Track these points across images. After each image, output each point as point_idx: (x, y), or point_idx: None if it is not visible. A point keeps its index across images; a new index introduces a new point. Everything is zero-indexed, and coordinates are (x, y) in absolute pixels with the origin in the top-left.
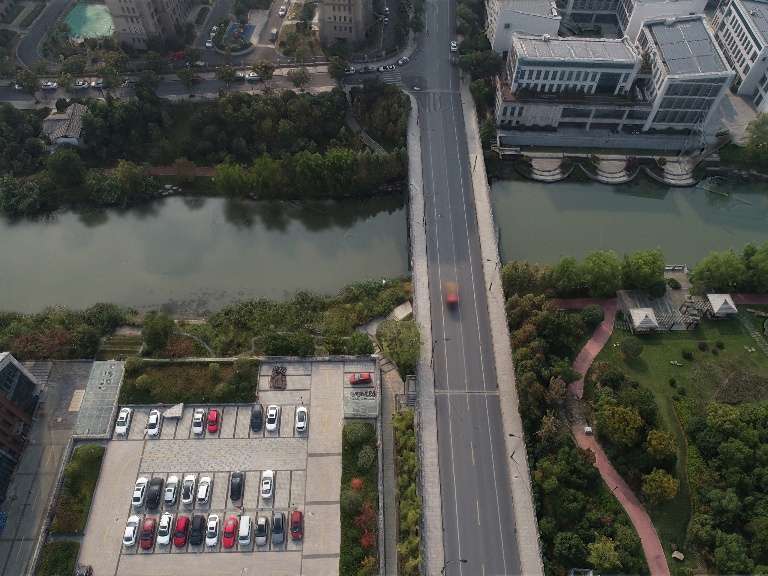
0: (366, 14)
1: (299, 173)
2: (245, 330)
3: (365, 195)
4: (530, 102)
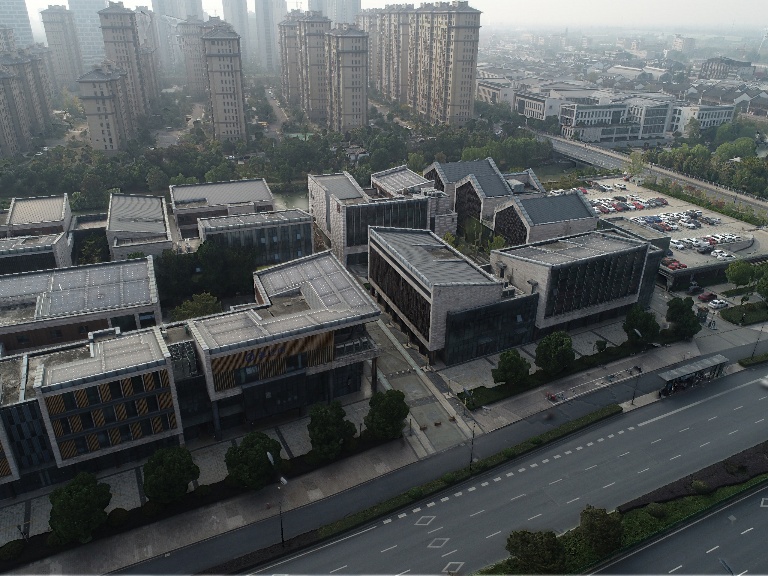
0: (475, 111)
1: (511, 147)
2: None
3: (535, 166)
4: (587, 127)
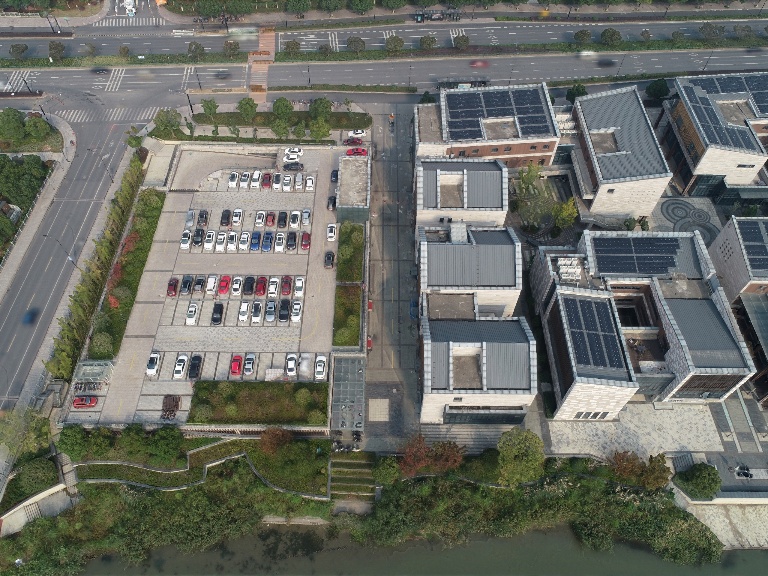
0: None
1: None
2: (214, 498)
3: None
4: None
